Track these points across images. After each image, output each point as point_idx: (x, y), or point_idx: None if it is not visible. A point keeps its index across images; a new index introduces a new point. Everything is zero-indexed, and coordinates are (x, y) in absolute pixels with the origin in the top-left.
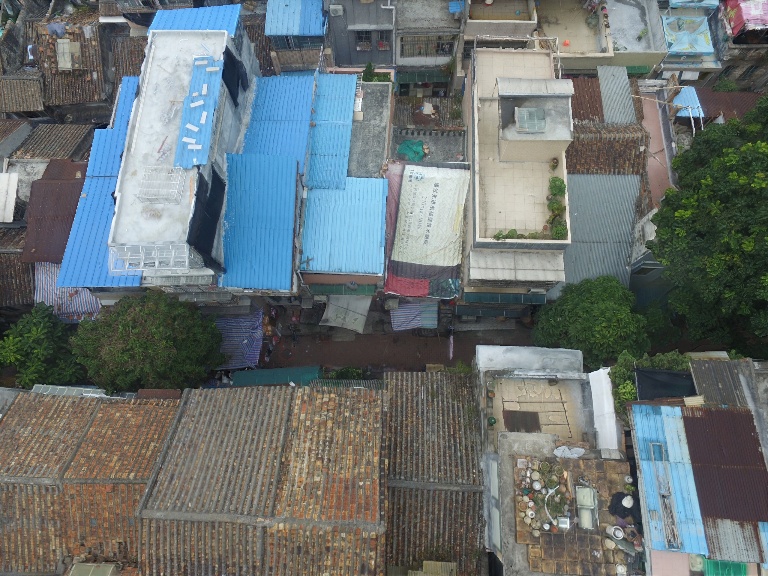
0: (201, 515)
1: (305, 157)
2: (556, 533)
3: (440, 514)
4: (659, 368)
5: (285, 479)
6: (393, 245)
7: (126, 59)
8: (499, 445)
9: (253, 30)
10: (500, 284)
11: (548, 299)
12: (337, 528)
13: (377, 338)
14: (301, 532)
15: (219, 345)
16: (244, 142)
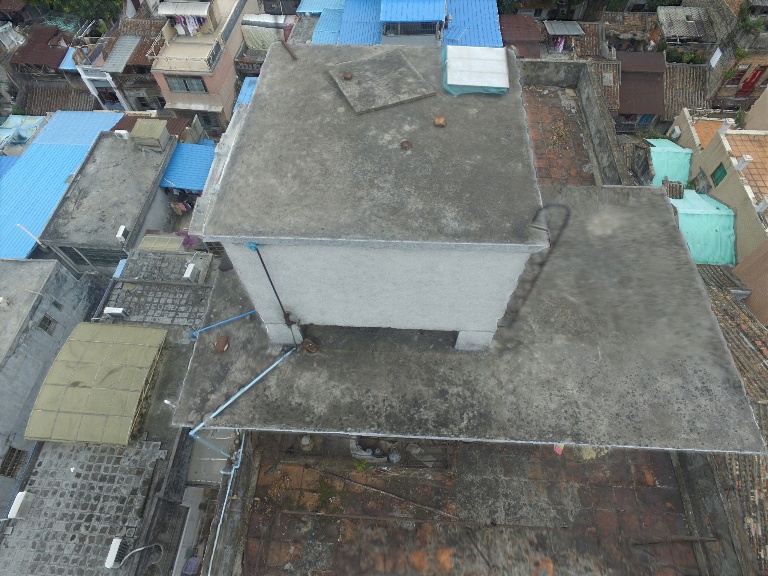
0: None
1: None
2: None
3: None
4: None
5: None
6: None
7: None
8: None
9: None
10: None
11: None
12: None
13: None
14: None
15: None
16: None
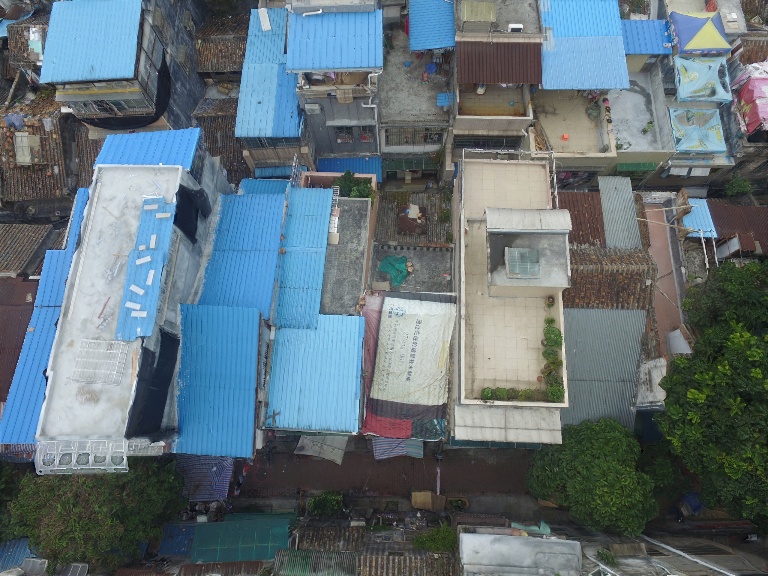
0: None
1: (273, 291)
2: None
3: None
4: None
5: None
6: (372, 382)
7: (91, 150)
8: None
9: (226, 121)
10: None
11: None
12: None
13: (359, 456)
14: None
15: (181, 489)
16: (204, 278)
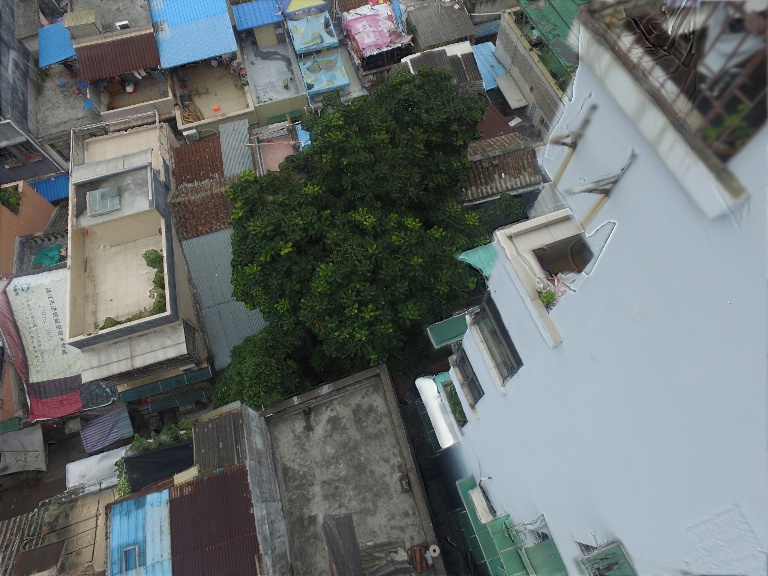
0: None
1: None
2: None
3: None
4: (172, 443)
5: None
6: (27, 367)
7: None
8: None
9: None
10: (136, 375)
11: (220, 369)
12: None
13: None
14: None
15: None
16: None
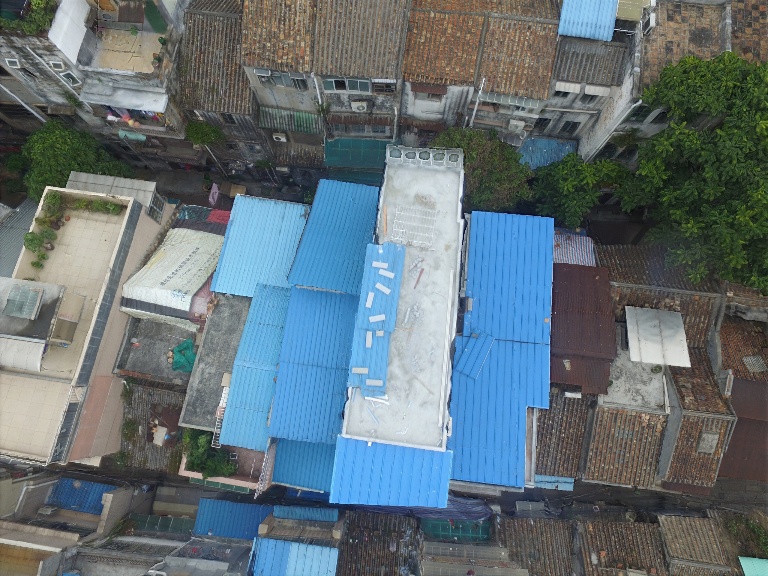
0: None
1: None
2: None
3: (223, 5)
4: (8, 20)
5: None
6: None
7: None
8: None
9: None
10: None
11: None
12: None
13: None
14: None
15: None
16: None
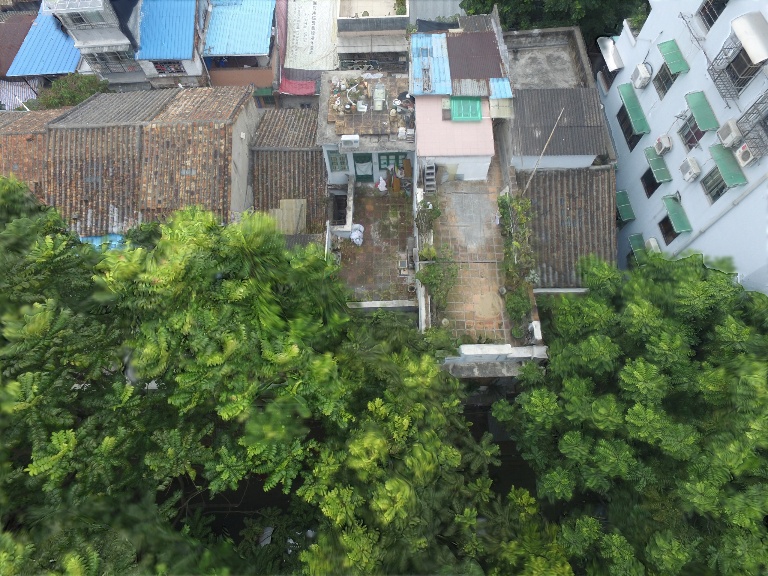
0: (94, 124)
1: None
2: (356, 114)
3: (295, 172)
4: None
5: (163, 112)
6: (285, 56)
7: None
8: (322, 78)
9: None
10: None
11: None
12: (195, 123)
13: None
14: (169, 129)
15: None
16: None
